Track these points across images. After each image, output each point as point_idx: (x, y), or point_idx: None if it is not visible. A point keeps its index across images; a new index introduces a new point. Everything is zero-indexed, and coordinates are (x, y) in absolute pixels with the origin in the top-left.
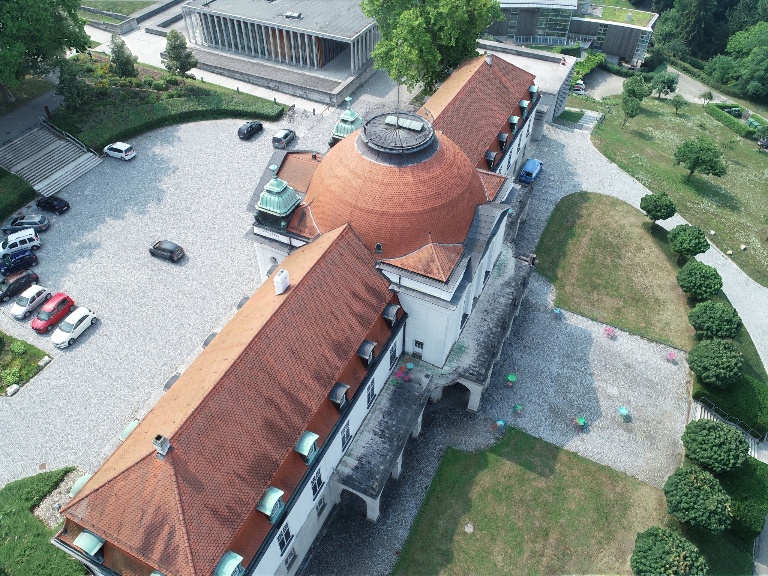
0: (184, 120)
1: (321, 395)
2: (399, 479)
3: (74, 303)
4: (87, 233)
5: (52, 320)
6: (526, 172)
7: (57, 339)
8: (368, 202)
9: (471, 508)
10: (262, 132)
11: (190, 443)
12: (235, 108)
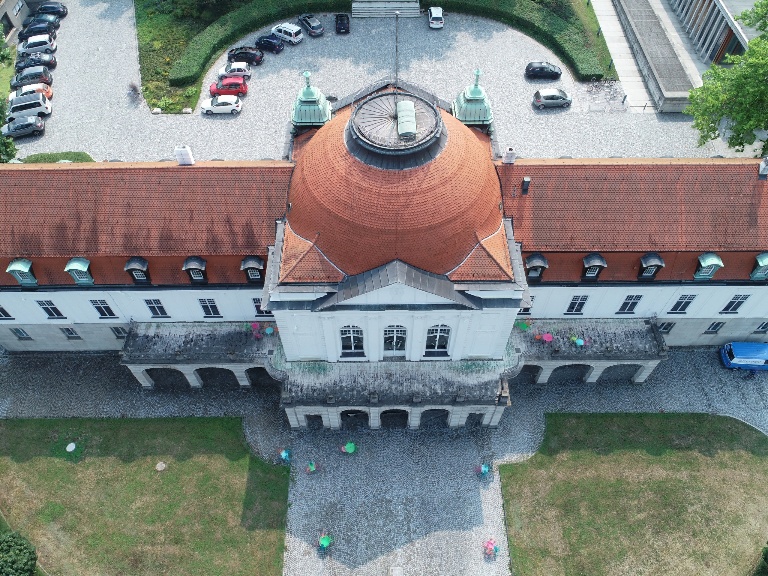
0: (518, 26)
1: (116, 251)
2: (193, 389)
3: (248, 93)
4: (326, 57)
5: (222, 91)
6: (730, 349)
7: (205, 104)
8: (308, 160)
9: (182, 461)
10: (551, 81)
11: (7, 184)
12: (564, 44)
